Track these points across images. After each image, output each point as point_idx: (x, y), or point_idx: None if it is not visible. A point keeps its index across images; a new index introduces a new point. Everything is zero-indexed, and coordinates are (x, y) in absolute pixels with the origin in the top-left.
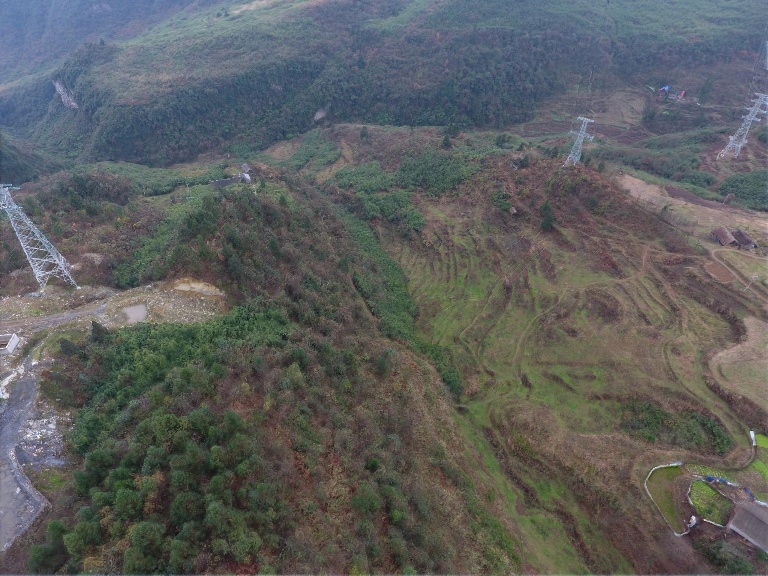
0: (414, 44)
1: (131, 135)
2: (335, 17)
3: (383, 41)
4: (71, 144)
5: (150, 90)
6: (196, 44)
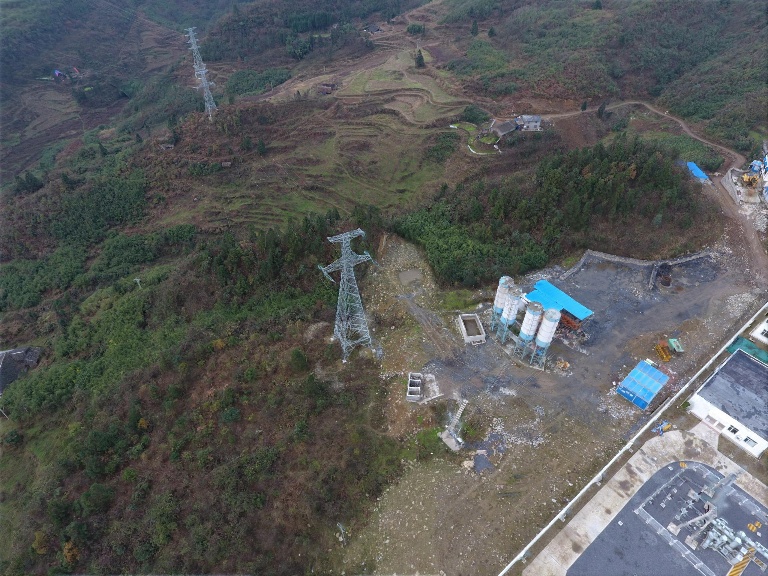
0: None
1: None
2: None
3: None
4: None
5: None
6: None
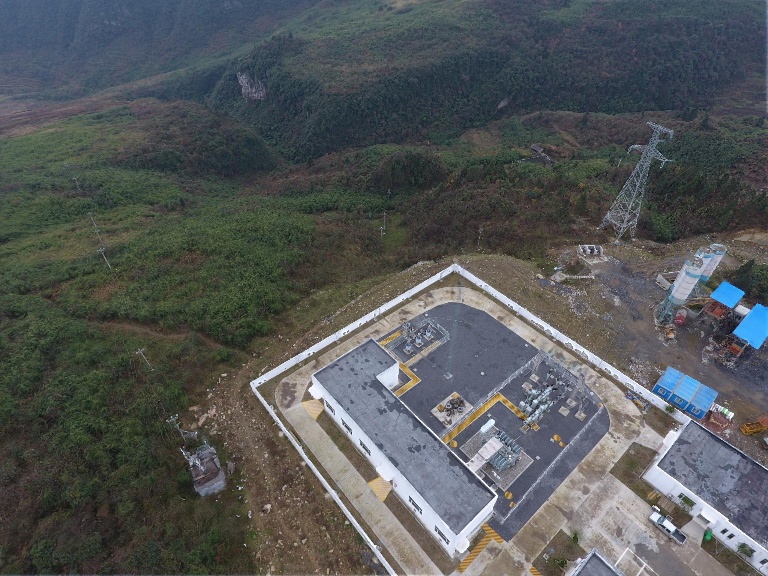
0: (595, 34)
1: (345, 123)
2: (512, 9)
3: (563, 32)
4: (265, 133)
5: (359, 80)
6: (389, 36)
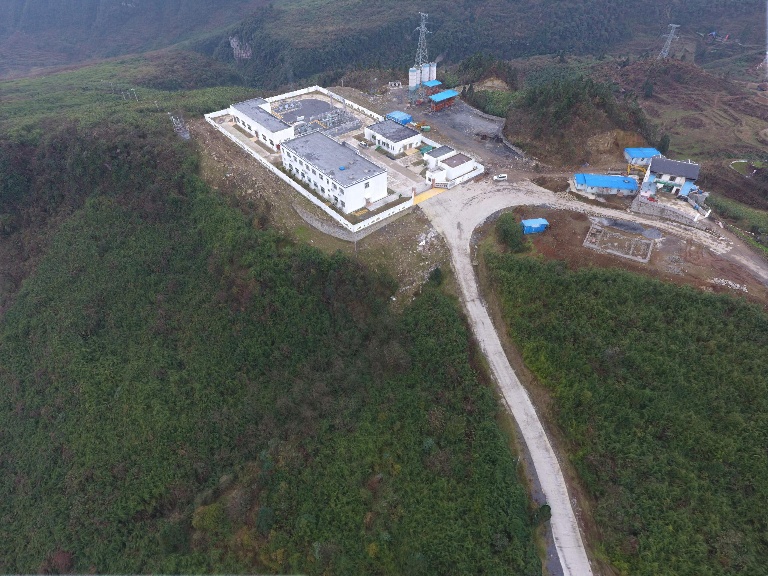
0: (513, 3)
1: (309, 70)
2: None
3: (488, 1)
4: (250, 83)
5: (321, 37)
6: (347, 5)
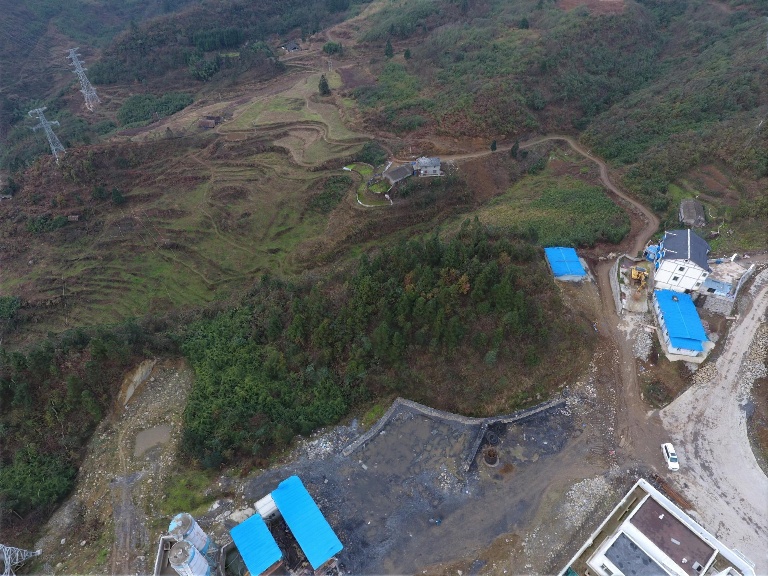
0: None
1: None
2: None
3: None
4: None
5: None
6: None
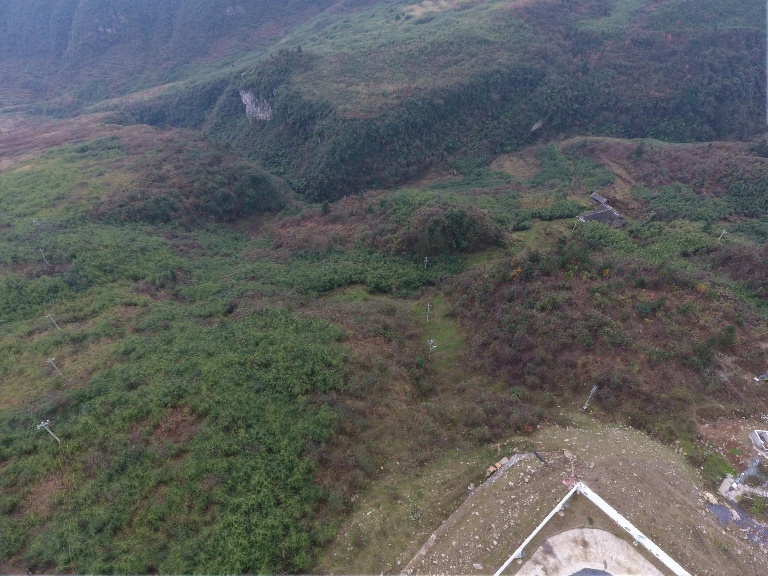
0: (641, 47)
1: (362, 151)
2: (546, 18)
3: (604, 44)
4: (271, 159)
5: (377, 102)
6: (410, 50)
